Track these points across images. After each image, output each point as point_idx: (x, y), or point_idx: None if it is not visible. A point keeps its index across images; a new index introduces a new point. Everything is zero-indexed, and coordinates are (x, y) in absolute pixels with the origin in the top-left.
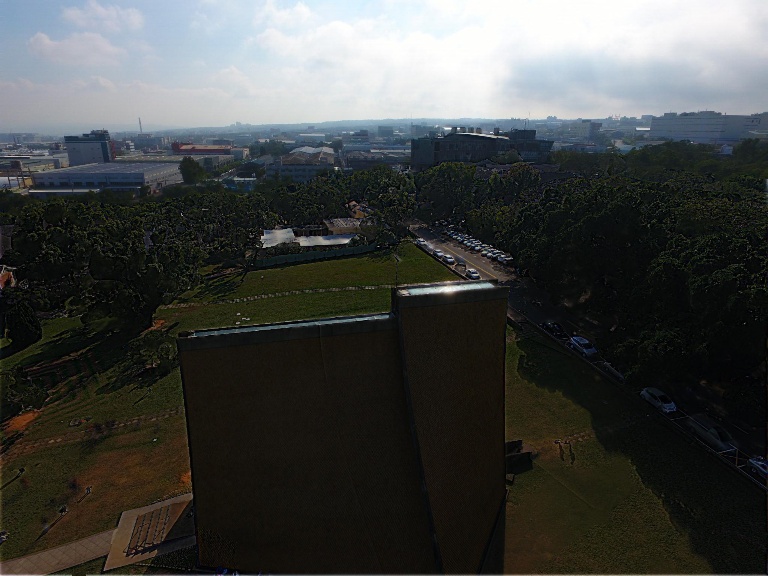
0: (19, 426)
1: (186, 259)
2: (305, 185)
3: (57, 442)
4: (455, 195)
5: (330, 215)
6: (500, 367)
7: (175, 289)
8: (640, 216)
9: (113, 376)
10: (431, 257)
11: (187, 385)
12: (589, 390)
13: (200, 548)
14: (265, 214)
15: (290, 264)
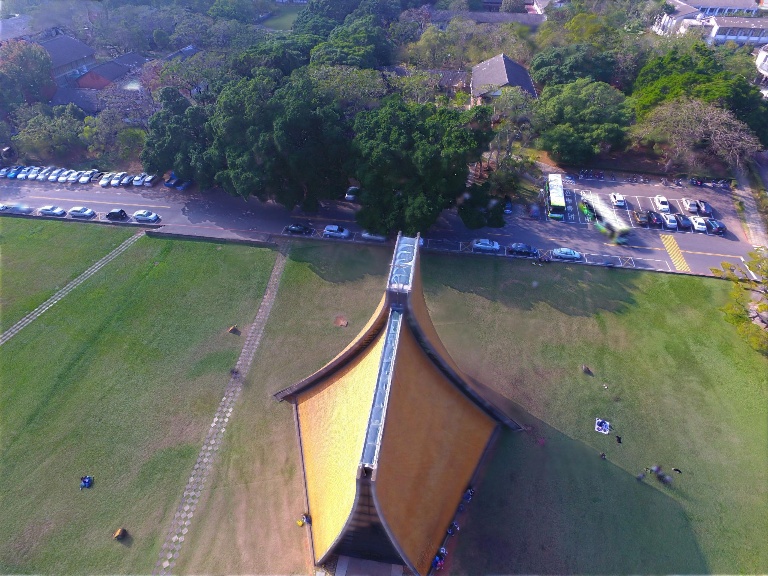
0: None
1: None
2: None
3: None
4: None
5: None
6: None
7: None
8: None
9: None
10: (48, 220)
11: None
12: (377, 260)
13: (420, 573)
14: None
15: None
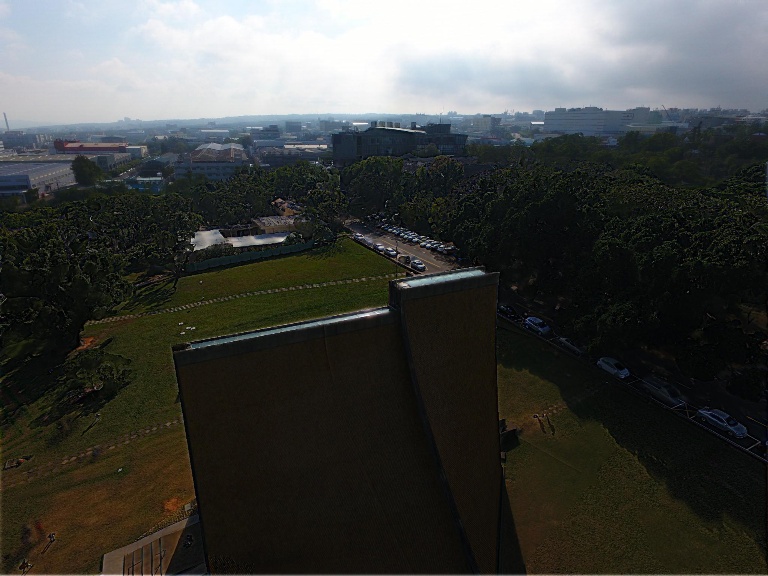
0: None
1: None
2: (224, 183)
3: None
4: (384, 189)
5: (256, 214)
6: (492, 351)
7: (104, 302)
8: (576, 202)
9: (46, 406)
10: (372, 251)
11: (186, 403)
12: (552, 365)
13: None
14: (187, 215)
15: (225, 267)
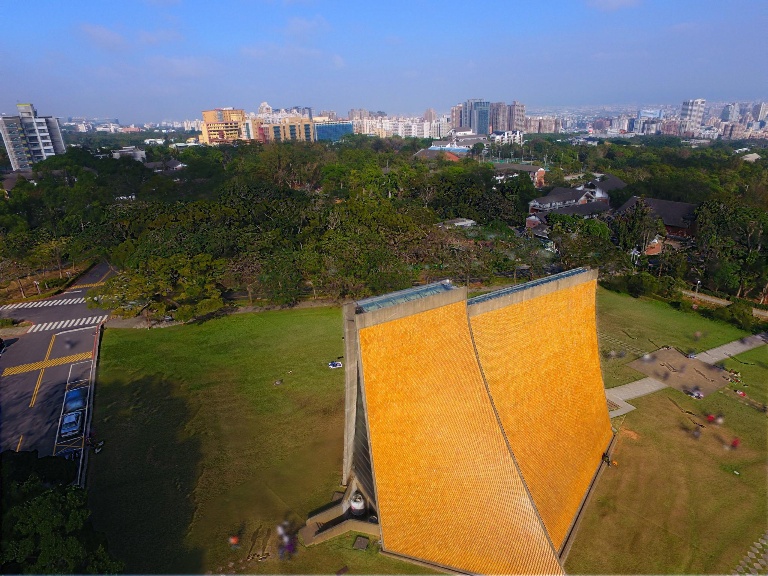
0: None
1: None
2: None
3: None
4: None
5: None
6: None
7: None
8: None
9: None
10: None
11: None
12: None
13: None
14: None
15: None
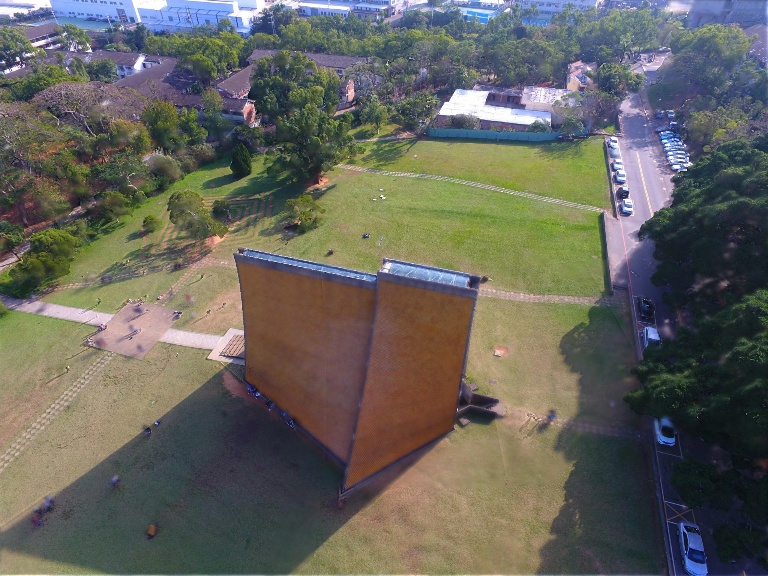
0: (213, 244)
1: (370, 118)
2: (538, 28)
3: (224, 264)
4: (706, 78)
5: None
6: (462, 347)
7: None
8: None
9: (273, 223)
10: (606, 167)
11: (242, 281)
12: (610, 386)
13: (246, 371)
14: (467, 71)
15: (460, 140)
